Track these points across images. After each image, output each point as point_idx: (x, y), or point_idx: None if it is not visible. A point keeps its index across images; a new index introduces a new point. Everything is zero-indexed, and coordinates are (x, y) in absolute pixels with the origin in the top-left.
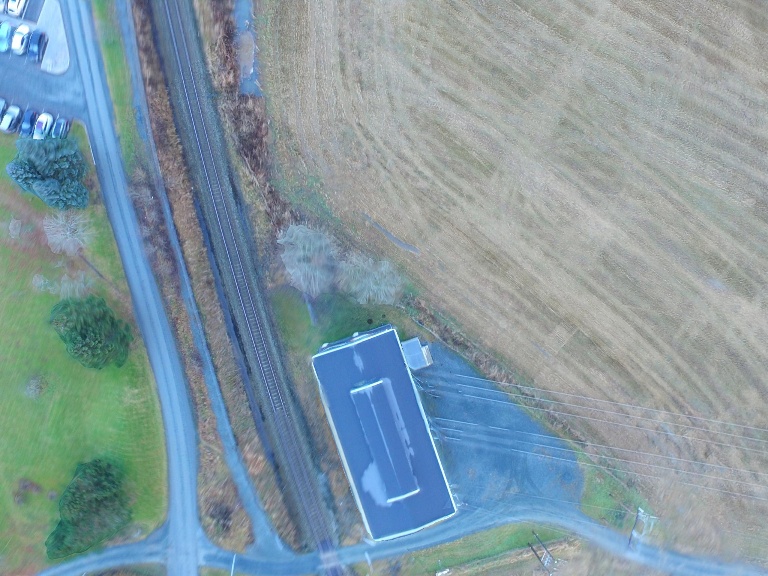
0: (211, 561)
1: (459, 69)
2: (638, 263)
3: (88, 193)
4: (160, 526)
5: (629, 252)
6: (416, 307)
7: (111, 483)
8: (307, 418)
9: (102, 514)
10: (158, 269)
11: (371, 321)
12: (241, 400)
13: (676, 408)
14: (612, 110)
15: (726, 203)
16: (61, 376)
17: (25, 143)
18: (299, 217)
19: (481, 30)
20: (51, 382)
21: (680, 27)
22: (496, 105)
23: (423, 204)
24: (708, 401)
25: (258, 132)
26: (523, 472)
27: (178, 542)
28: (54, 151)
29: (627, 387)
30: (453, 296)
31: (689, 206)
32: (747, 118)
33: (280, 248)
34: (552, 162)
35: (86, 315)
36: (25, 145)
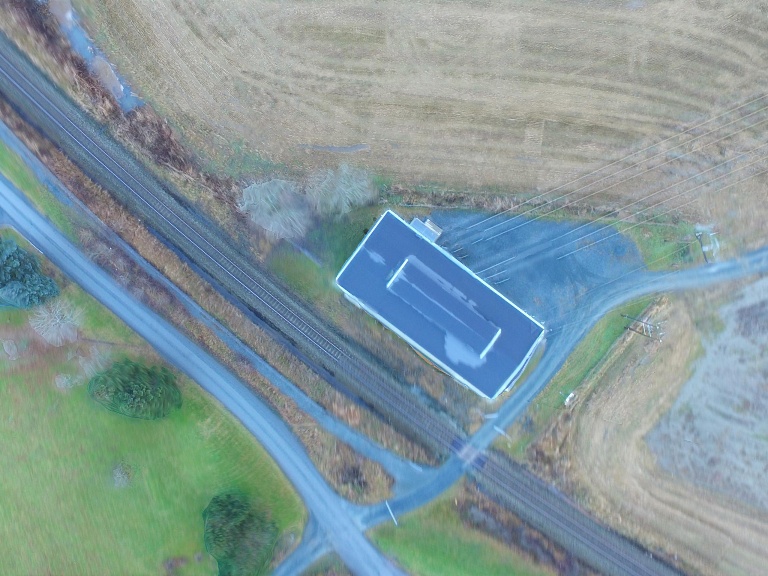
0: (370, 521)
1: None
2: (557, 31)
3: (53, 280)
4: (307, 521)
5: (543, 27)
6: (396, 194)
7: (240, 508)
8: (369, 349)
9: (249, 536)
10: (157, 306)
11: (367, 231)
12: (303, 371)
13: (671, 132)
14: None
15: None
16: (137, 452)
17: None
18: (246, 184)
19: None
20: (132, 463)
21: None
22: None
23: (343, 103)
24: (693, 108)
25: (163, 135)
26: (580, 271)
27: (331, 524)
28: None
29: (618, 142)
30: (421, 164)
31: None
32: None
33: (248, 220)
34: None
35: (120, 375)
36: None
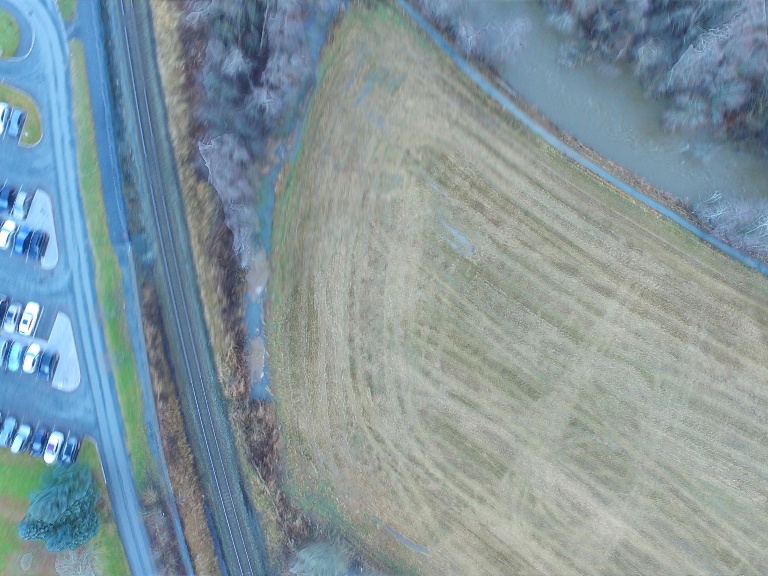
0: None
1: (469, 371)
2: (650, 561)
3: (99, 515)
4: None
5: (641, 550)
6: None
7: None
8: None
9: None
10: None
11: None
12: None
13: None
14: (622, 410)
15: (737, 502)
16: None
17: (38, 511)
18: (310, 523)
19: (491, 332)
20: None
21: (689, 327)
22: (506, 406)
23: (434, 506)
24: None
25: (269, 440)
26: None
27: None
28: (66, 502)
29: None
30: None
31: (700, 503)
32: (757, 416)
33: (291, 557)
34: (563, 462)
35: None
36: (38, 513)
